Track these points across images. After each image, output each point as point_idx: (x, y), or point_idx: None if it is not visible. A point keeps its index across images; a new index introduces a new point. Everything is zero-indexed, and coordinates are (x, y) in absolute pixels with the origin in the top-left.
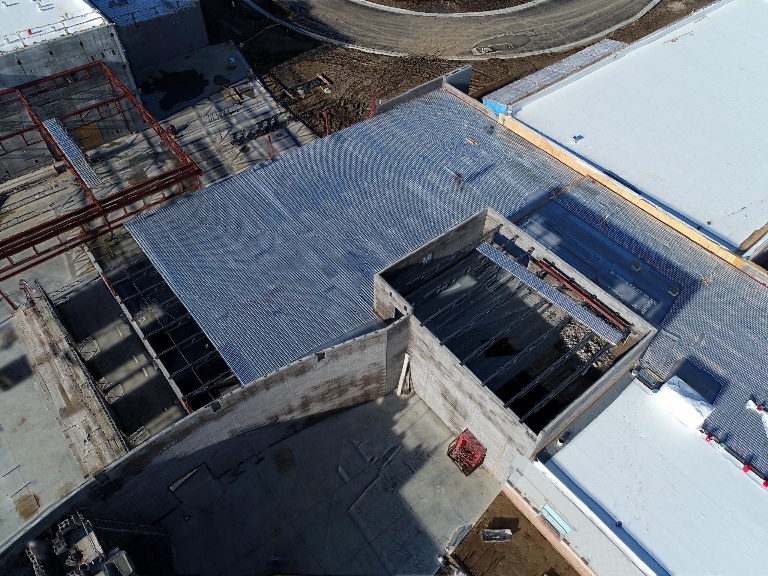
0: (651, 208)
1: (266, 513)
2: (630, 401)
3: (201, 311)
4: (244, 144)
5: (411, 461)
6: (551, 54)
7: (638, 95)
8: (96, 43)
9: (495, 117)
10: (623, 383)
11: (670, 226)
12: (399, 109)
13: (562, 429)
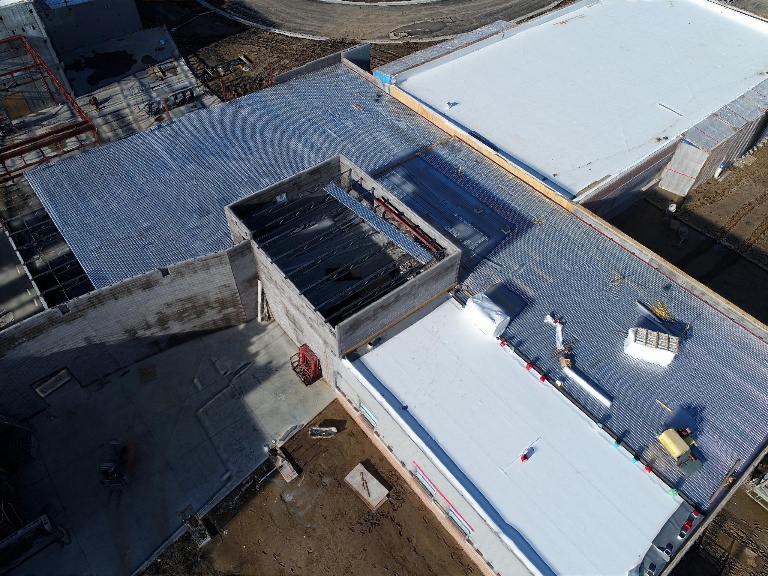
0: (503, 162)
1: (123, 414)
2: (442, 315)
3: (79, 243)
4: (160, 114)
5: (260, 374)
6: None
7: (518, 69)
8: (16, 18)
9: (383, 87)
10: (439, 301)
11: (519, 177)
12: (297, 80)
13: (374, 335)
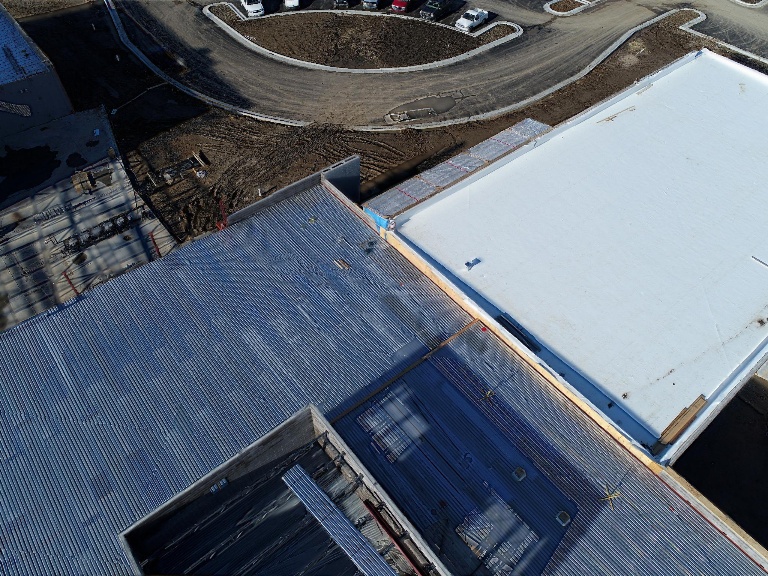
0: (550, 376)
1: None
2: None
3: None
4: (80, 251)
5: None
6: (477, 123)
7: (557, 197)
8: None
9: (377, 229)
10: None
11: (573, 402)
12: (260, 217)
13: None
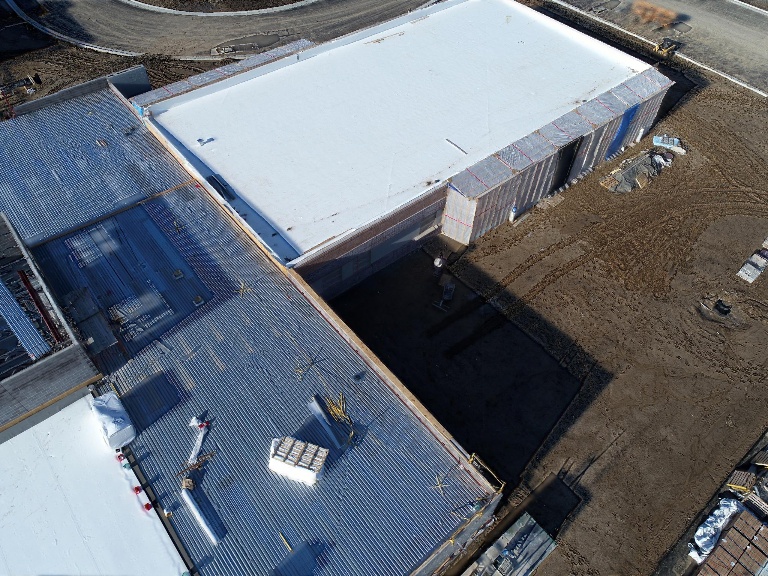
0: (231, 214)
1: None
2: (66, 418)
3: None
4: None
5: None
6: None
7: (302, 97)
8: None
9: (140, 119)
10: (72, 399)
11: (245, 232)
12: (47, 110)
13: None
